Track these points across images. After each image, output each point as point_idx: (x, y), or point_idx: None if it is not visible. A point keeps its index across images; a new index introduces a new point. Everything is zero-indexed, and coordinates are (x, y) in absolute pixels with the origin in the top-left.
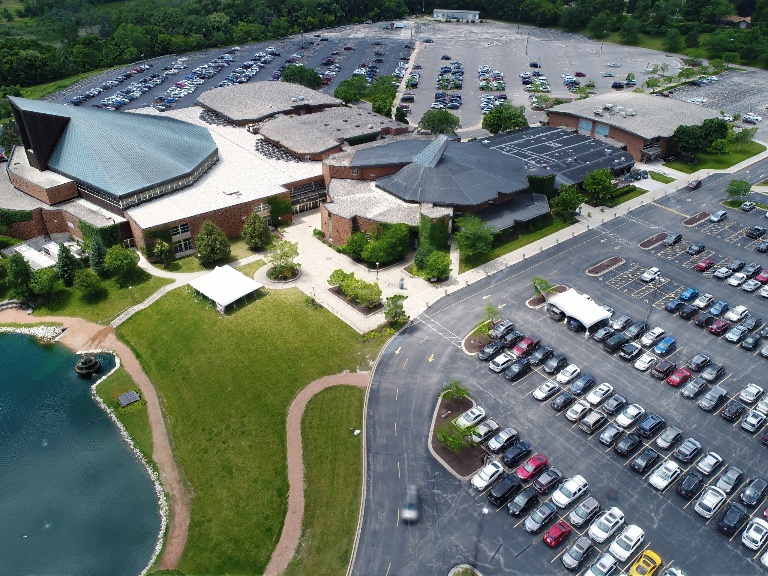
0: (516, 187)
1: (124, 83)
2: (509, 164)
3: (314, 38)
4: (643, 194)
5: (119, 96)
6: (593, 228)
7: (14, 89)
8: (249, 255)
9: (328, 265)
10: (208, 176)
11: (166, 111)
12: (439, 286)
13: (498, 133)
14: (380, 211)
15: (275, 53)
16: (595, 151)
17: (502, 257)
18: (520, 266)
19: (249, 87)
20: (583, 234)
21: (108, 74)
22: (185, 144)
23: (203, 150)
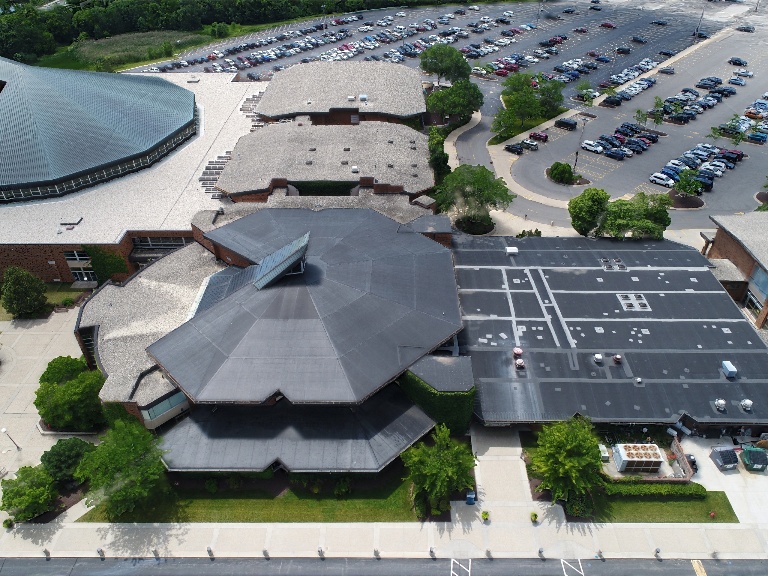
0: (329, 394)
1: (308, 35)
2: (411, 329)
3: (587, 4)
4: (706, 522)
5: (276, 50)
6: (448, 558)
7: (219, 27)
8: (3, 319)
9: (28, 384)
10: (99, 187)
11: (237, 82)
12: (16, 528)
13: (588, 234)
14: (135, 332)
15: (504, 19)
16: (701, 354)
17: (187, 525)
18: (178, 570)
19: (344, 67)
20: (403, 562)
21: (313, 22)
22: (103, 139)
23: (117, 151)
